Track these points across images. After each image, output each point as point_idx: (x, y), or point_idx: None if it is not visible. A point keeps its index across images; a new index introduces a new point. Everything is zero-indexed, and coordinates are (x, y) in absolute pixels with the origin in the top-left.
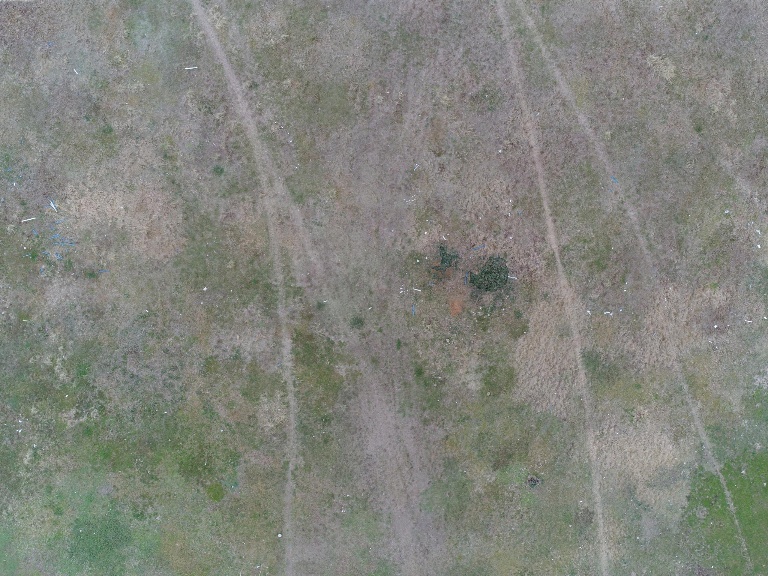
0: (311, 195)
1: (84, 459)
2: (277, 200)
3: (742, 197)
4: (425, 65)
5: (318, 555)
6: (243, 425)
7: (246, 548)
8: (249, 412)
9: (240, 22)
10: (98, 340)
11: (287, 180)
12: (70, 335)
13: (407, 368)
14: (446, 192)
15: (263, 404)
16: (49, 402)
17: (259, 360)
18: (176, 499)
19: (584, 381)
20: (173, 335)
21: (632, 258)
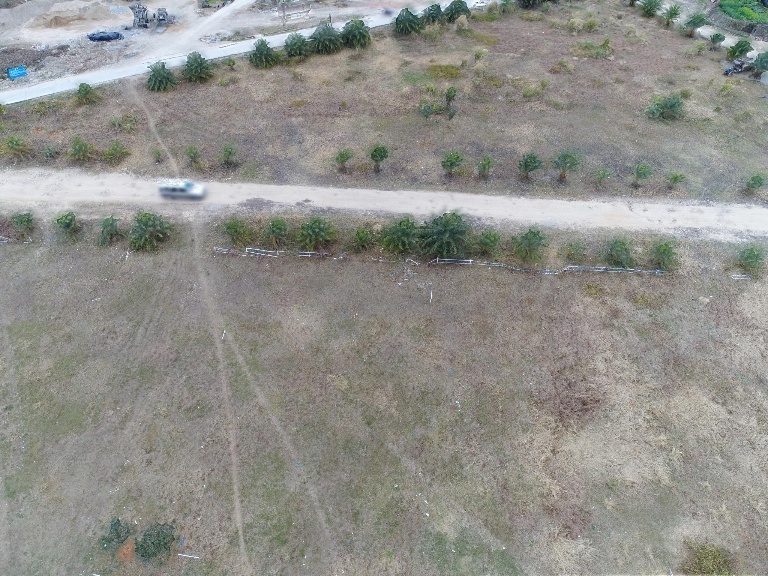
0: (23, 490)
1: None
2: None
3: (409, 473)
4: (154, 389)
5: None
6: None
7: None
8: None
9: (17, 367)
10: None
11: (7, 479)
12: None
13: None
14: (148, 482)
15: None
16: None
17: None
18: None
19: None
20: None
21: (311, 532)
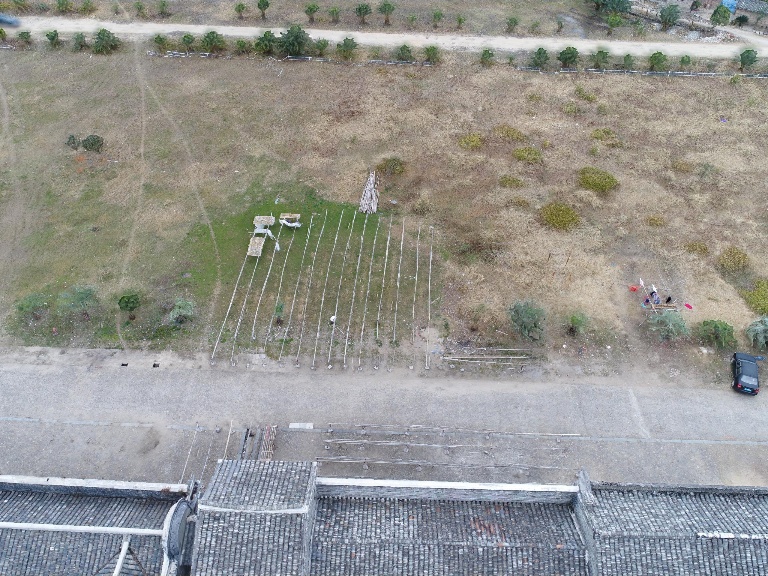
0: (24, 140)
1: None
2: (5, 142)
3: None
4: (101, 107)
5: None
6: None
7: None
8: None
9: None
10: None
11: (14, 137)
12: None
13: (42, 192)
14: None
15: None
16: None
17: None
18: None
19: (141, 193)
20: None
21: (181, 155)
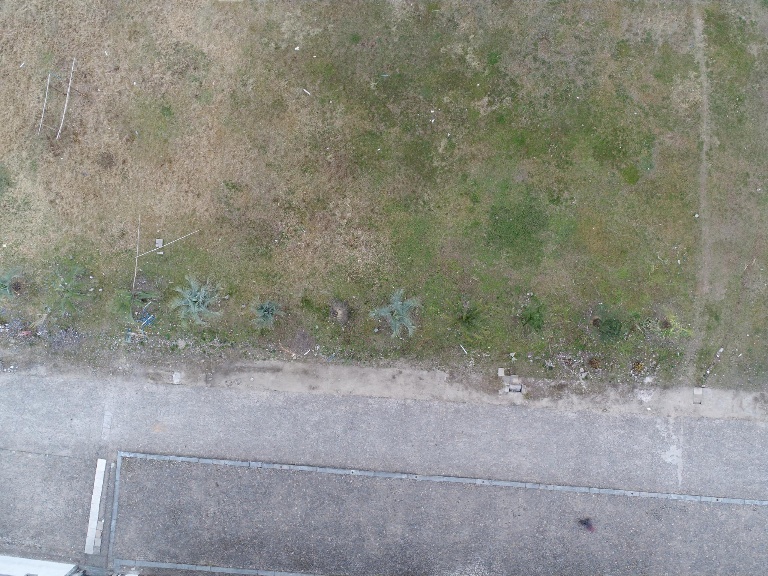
0: None
1: (498, 147)
2: None
3: None
4: None
5: (735, 234)
6: (657, 107)
7: (663, 229)
8: (663, 94)
9: None
10: (508, 28)
11: None
12: (480, 24)
13: None
14: None
15: (676, 86)
16: (461, 91)
17: (671, 42)
18: (591, 183)
19: None
20: (583, 20)
21: None
